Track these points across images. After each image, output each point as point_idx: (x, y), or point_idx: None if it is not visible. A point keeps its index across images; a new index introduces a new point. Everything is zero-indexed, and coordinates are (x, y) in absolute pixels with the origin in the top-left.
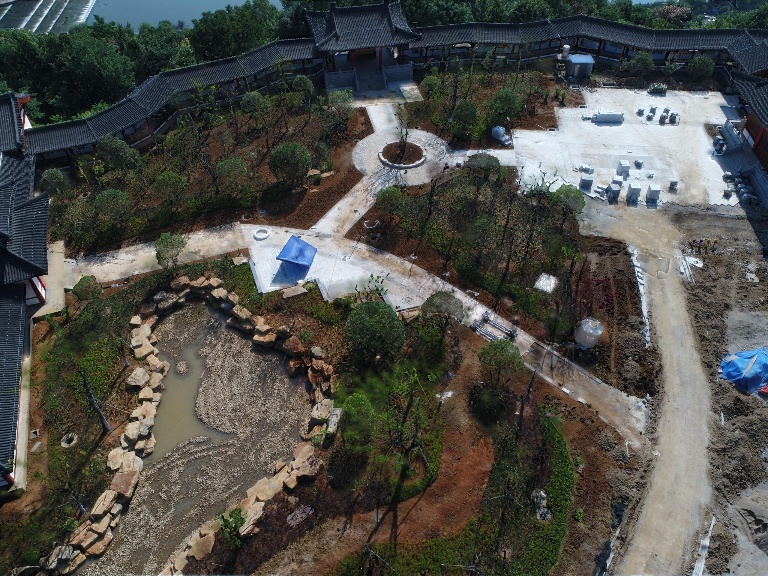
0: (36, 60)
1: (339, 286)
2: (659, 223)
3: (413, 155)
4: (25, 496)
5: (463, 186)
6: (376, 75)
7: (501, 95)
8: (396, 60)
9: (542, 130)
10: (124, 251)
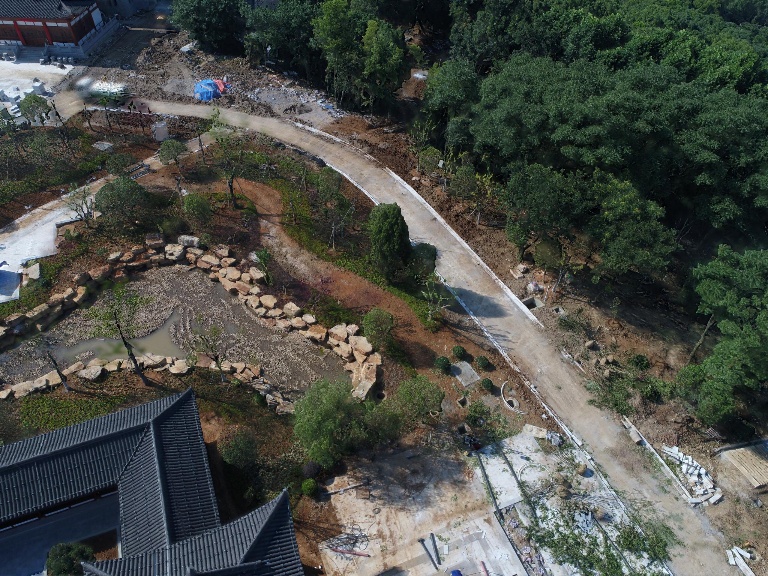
0: None
1: (39, 250)
2: (71, 95)
3: None
4: None
5: None
6: None
7: None
8: None
9: None
10: None
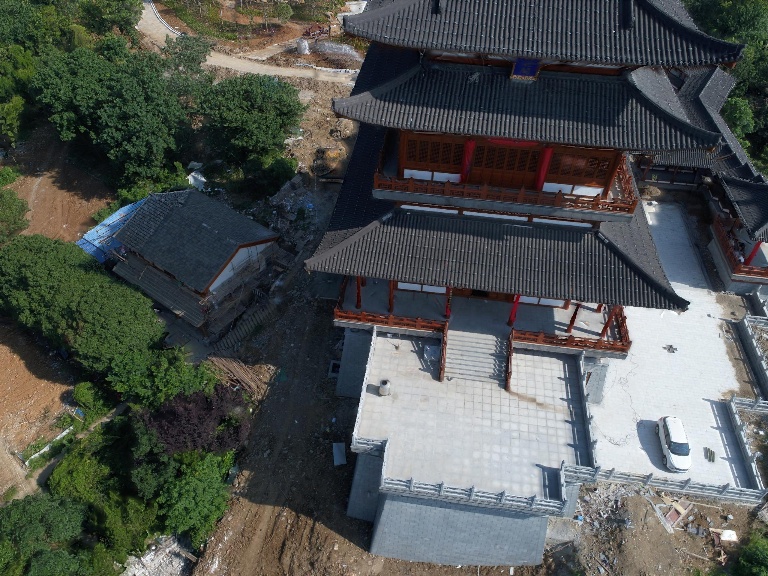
0: None
1: (357, 7)
2: None
3: None
4: None
5: None
6: None
7: None
8: None
9: None
10: None
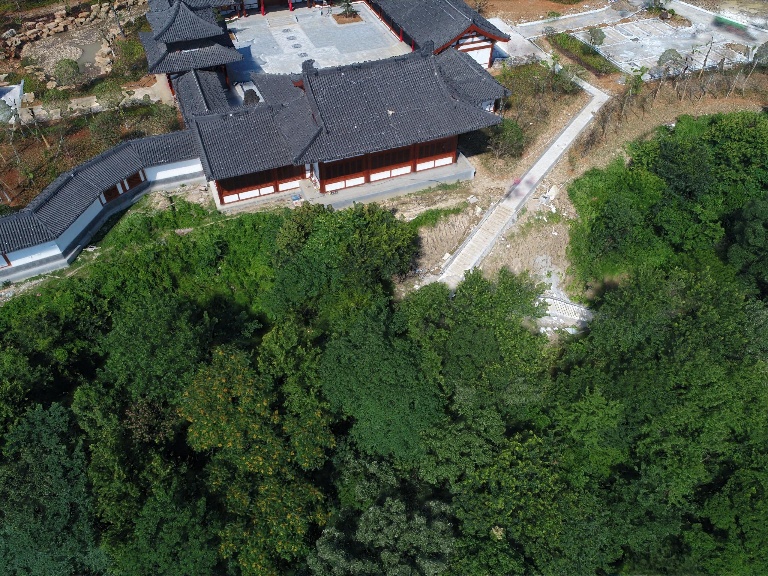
0: None
1: None
2: None
3: None
4: None
5: None
6: None
7: None
8: None
9: None
10: None
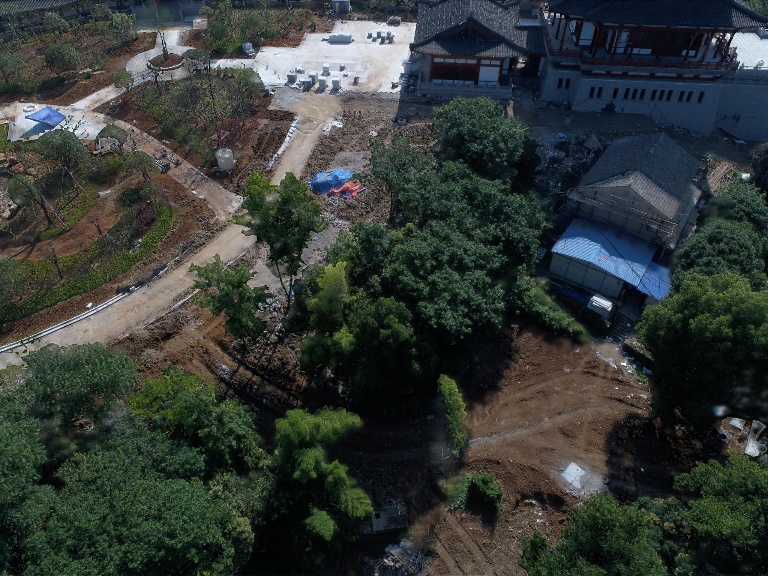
0: None
1: None
2: (330, 103)
3: (173, 62)
4: None
5: None
6: (175, 10)
7: (247, 17)
8: (198, 0)
9: (285, 47)
10: None
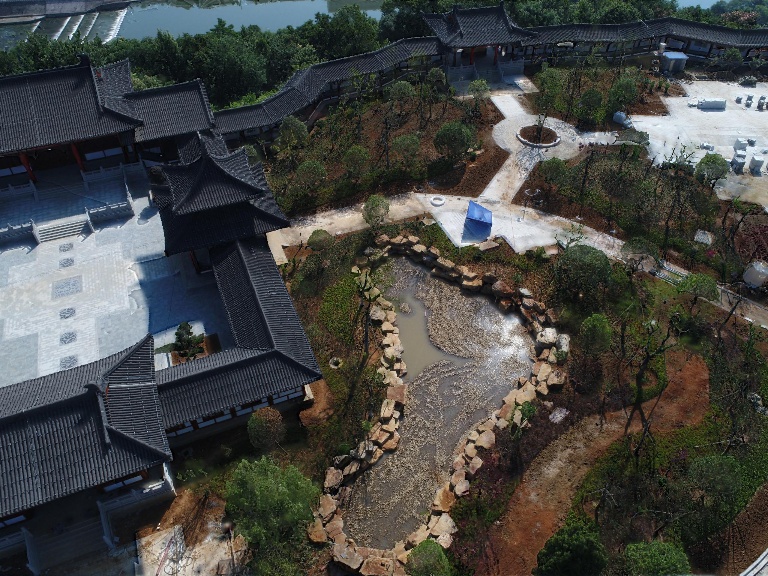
0: (174, 58)
1: (523, 242)
2: None
3: (549, 136)
4: (316, 405)
5: (604, 161)
6: (492, 70)
7: (623, 84)
8: (505, 57)
9: (656, 115)
10: (320, 216)
